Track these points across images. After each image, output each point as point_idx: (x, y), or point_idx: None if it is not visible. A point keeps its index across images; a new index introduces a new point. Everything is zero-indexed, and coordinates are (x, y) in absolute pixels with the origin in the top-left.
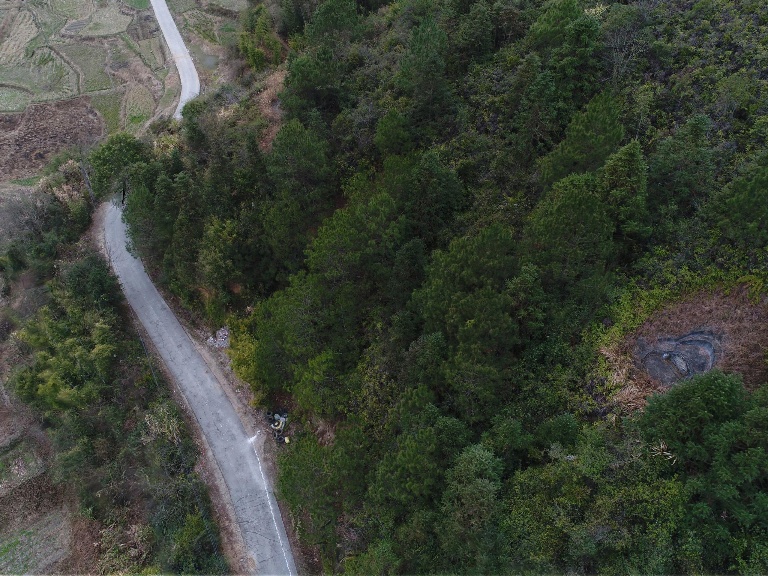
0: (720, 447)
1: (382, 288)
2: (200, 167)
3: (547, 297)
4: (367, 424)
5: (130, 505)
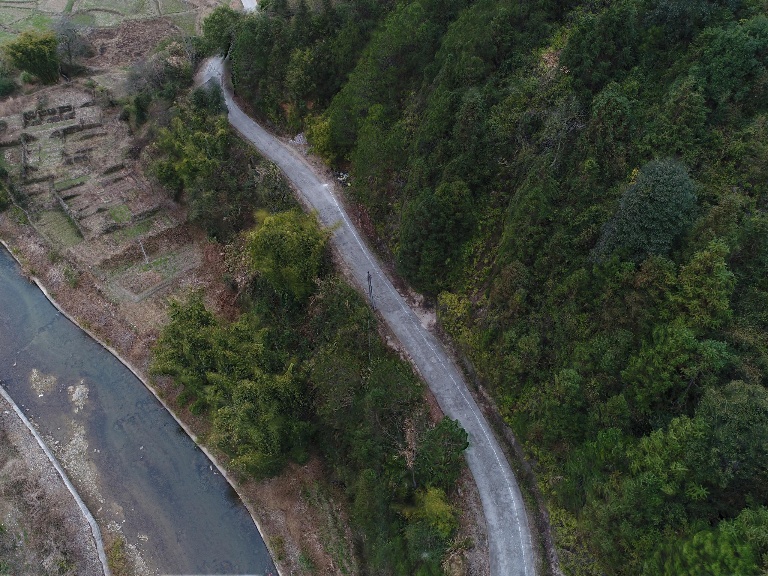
0: (585, 45)
1: (414, 73)
2: (287, 17)
3: (513, 29)
4: (406, 144)
5: (243, 231)
